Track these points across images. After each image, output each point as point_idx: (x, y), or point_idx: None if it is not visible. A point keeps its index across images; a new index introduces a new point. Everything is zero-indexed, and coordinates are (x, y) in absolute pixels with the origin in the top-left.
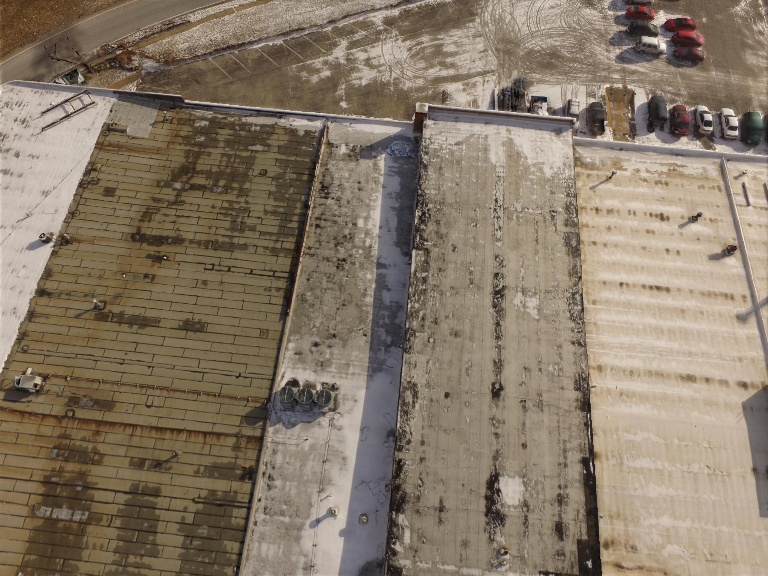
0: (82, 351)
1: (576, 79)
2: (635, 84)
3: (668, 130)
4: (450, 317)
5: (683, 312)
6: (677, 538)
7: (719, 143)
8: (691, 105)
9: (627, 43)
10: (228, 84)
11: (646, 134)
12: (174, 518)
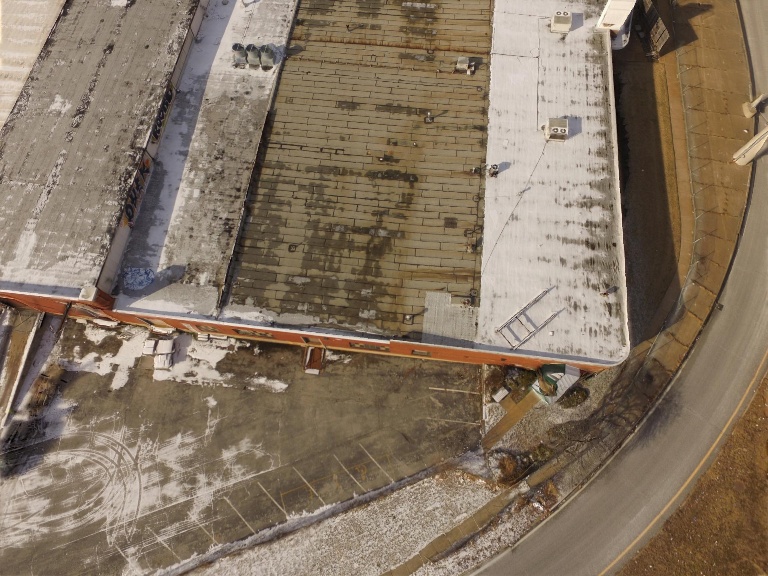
0: (434, 88)
1: None
2: None
3: None
4: (128, 95)
5: None
6: None
7: None
8: None
9: None
10: (364, 435)
11: None
12: (347, 3)
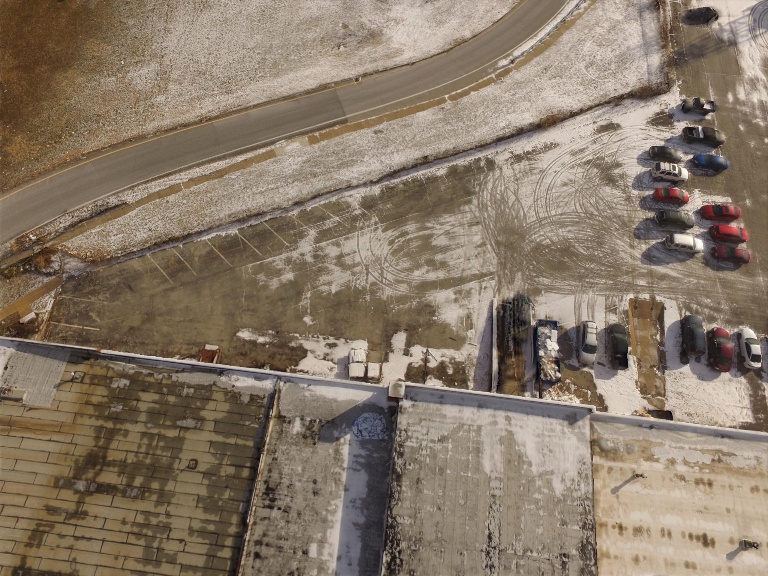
0: None
1: (593, 286)
2: (665, 294)
3: (706, 361)
4: None
5: None
6: None
7: None
8: (734, 325)
9: (655, 235)
10: (168, 291)
11: (679, 367)
12: None
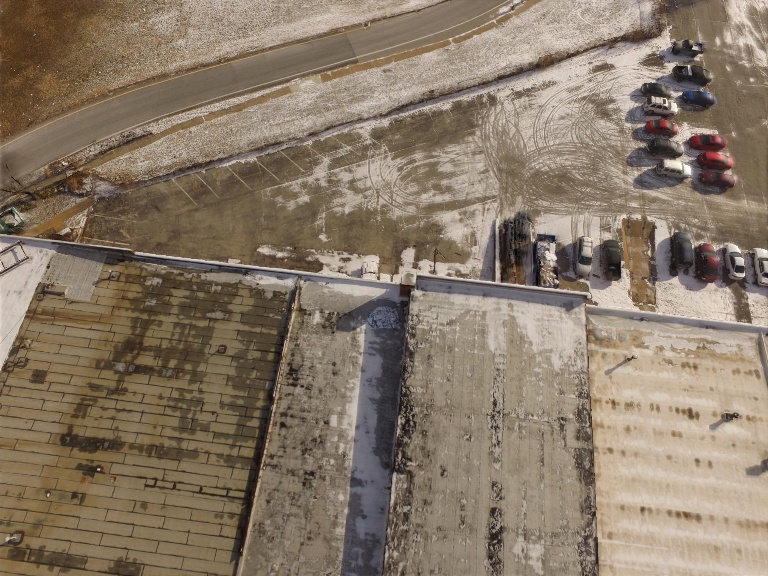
0: None
1: (588, 208)
2: (656, 215)
3: (693, 273)
4: (436, 572)
5: (717, 550)
6: None
7: (752, 291)
8: (719, 242)
9: (647, 163)
10: (192, 211)
11: (668, 278)
12: None
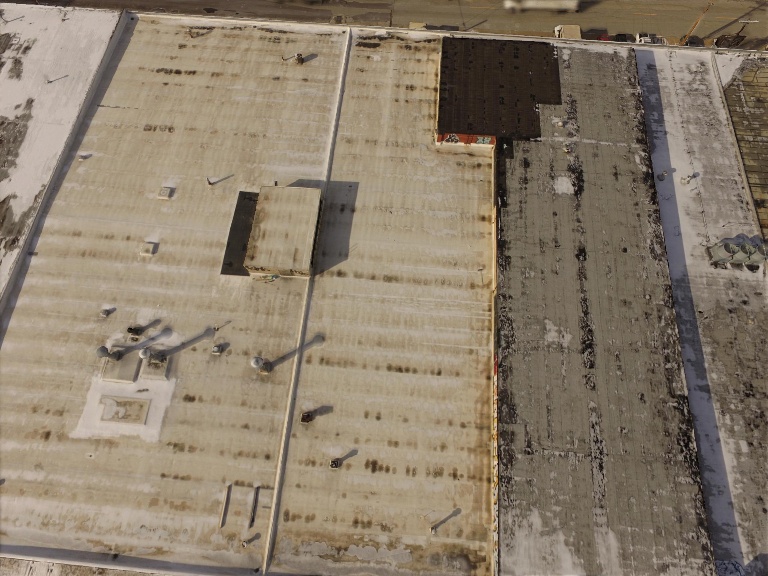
0: None
1: None
2: None
3: None
4: (634, 320)
5: (379, 343)
6: (426, 170)
7: None
8: None
9: None
10: None
11: None
12: None
